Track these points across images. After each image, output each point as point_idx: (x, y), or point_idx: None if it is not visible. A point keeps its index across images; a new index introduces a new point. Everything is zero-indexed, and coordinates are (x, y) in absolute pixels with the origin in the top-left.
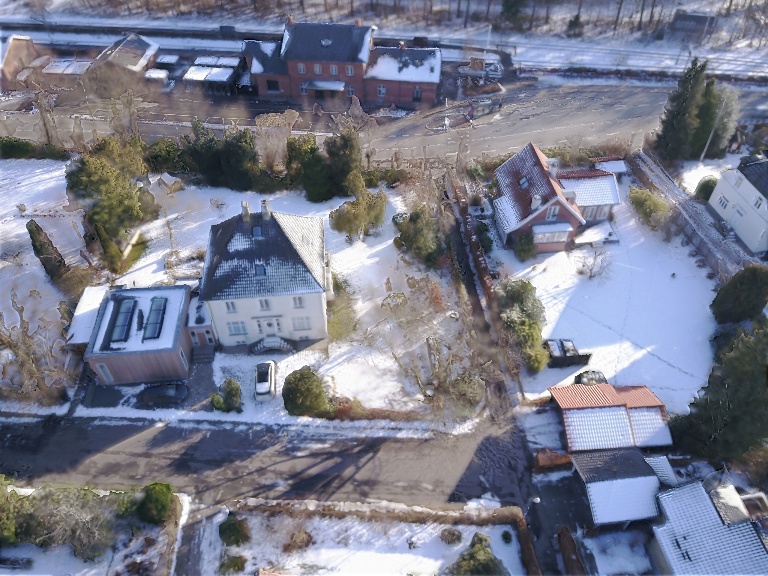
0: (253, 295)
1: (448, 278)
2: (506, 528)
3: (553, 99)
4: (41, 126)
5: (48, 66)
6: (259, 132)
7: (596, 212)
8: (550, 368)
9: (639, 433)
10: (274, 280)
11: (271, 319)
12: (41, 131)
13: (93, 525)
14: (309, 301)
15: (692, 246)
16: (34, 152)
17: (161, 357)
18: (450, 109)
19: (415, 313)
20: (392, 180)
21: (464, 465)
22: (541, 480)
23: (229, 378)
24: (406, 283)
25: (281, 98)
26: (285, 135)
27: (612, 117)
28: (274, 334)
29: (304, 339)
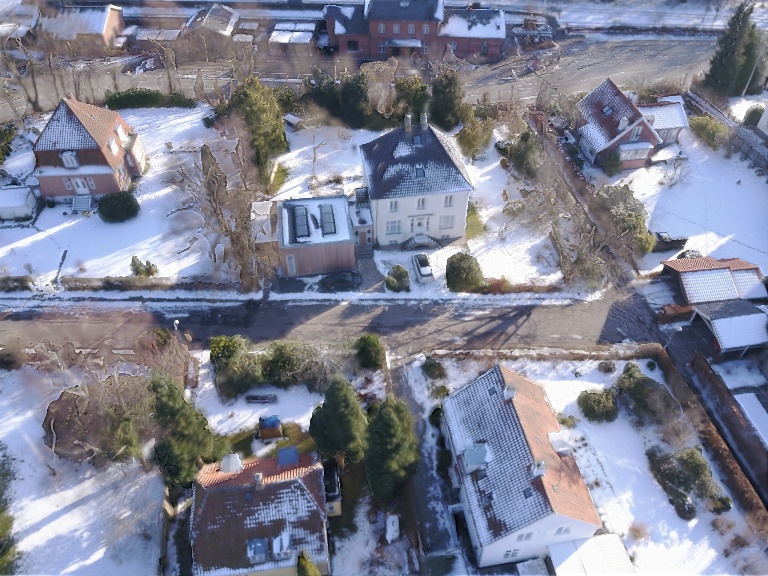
0: (415, 194)
1: (552, 190)
2: (649, 360)
3: (602, 52)
4: (165, 79)
5: (140, 34)
6: (371, 76)
7: (666, 135)
8: (653, 253)
9: (741, 289)
10: (432, 181)
11: (423, 218)
12: (164, 84)
13: None
14: (458, 200)
15: (750, 160)
16: (163, 101)
17: (340, 248)
18: (514, 62)
19: (533, 216)
20: (485, 117)
21: (602, 321)
22: (667, 329)
23: (396, 265)
24: (519, 194)
25: (360, 57)
26: (388, 80)
27: (657, 65)
28: (422, 233)
29: (445, 238)
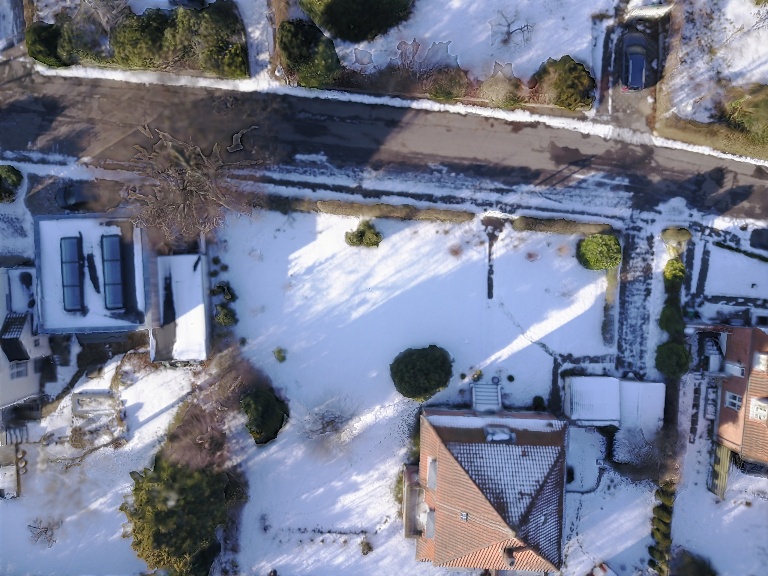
0: None
1: None
2: None
3: None
4: None
5: None
6: None
7: None
8: None
9: None
10: None
11: None
12: None
13: (96, 14)
14: None
15: None
16: None
17: None
18: None
19: None
20: None
21: None
22: None
23: None
24: None
25: None
26: None
27: None
28: None
29: None
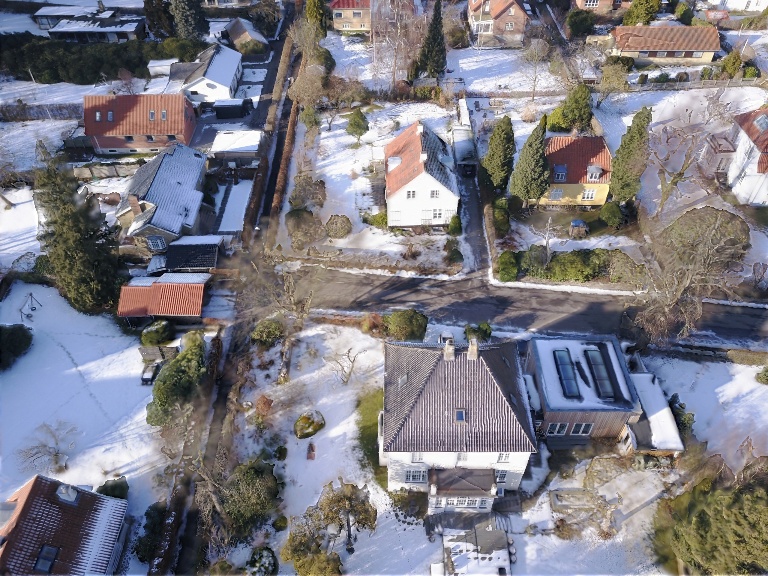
0: None
1: None
2: None
3: None
4: None
5: None
6: None
7: None
8: None
9: None
10: None
11: None
12: None
13: (544, 249)
14: None
15: None
16: None
17: None
18: None
19: (289, 413)
20: None
21: None
22: None
23: None
24: None
25: None
26: None
27: None
28: None
29: None
